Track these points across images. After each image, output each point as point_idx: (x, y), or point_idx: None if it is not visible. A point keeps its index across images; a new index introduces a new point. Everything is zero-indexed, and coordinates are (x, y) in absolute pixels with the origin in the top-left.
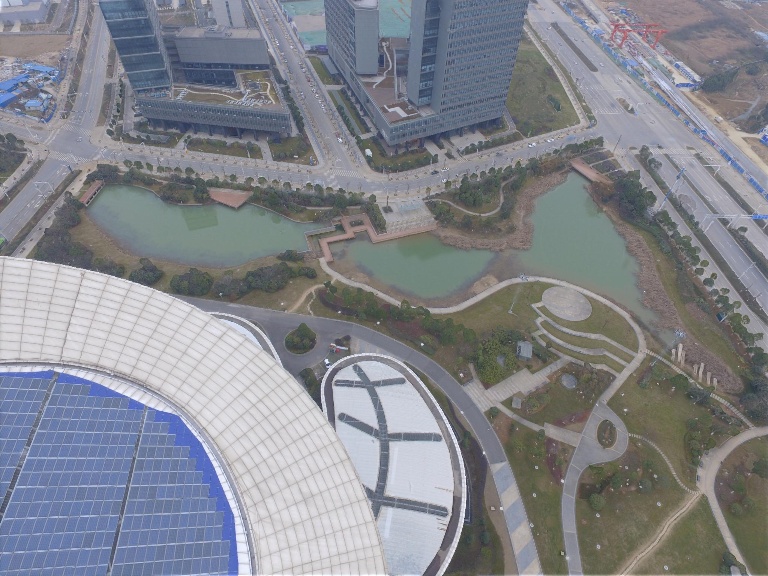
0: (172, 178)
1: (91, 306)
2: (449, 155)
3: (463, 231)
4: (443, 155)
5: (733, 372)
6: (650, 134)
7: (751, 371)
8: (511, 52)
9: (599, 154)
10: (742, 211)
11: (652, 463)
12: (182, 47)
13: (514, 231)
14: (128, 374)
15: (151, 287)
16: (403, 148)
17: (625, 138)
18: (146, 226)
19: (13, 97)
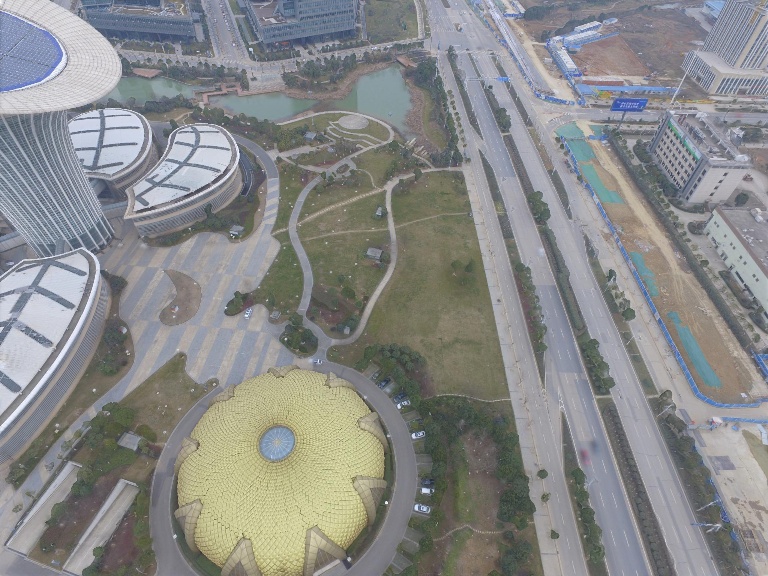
0: None
1: None
2: (310, 53)
3: (302, 90)
4: (306, 53)
5: (441, 150)
6: (465, 43)
7: None
8: None
9: (419, 53)
10: (502, 81)
11: None
12: None
13: (337, 90)
14: (29, 18)
15: (84, 112)
16: None
17: (446, 45)
18: None
19: None
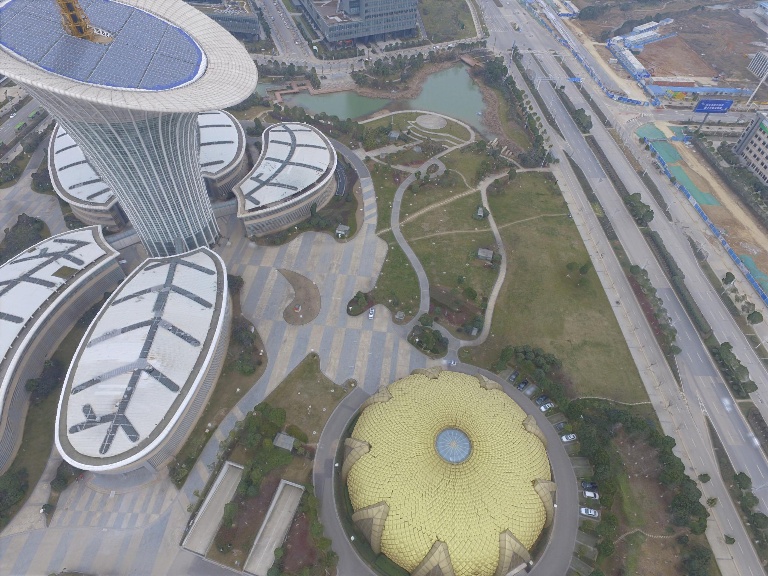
0: None
1: None
2: (373, 51)
3: (373, 89)
4: (369, 52)
5: (524, 150)
6: (526, 42)
7: None
8: None
9: (482, 52)
10: (571, 82)
11: None
12: None
13: (408, 89)
14: (162, 16)
15: None
16: (341, 47)
17: (506, 45)
18: None
19: None
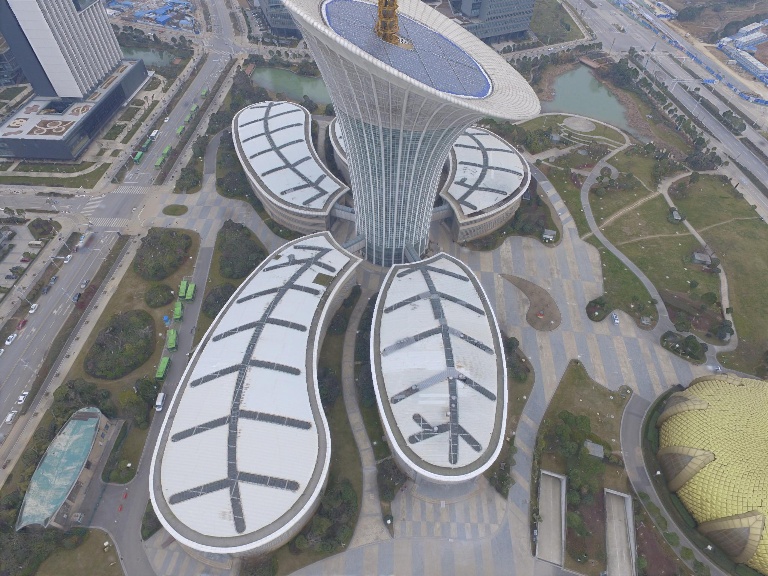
0: (302, 63)
1: None
2: None
3: None
4: None
5: (684, 153)
6: (636, 44)
7: (695, 151)
8: None
9: (599, 54)
10: (699, 83)
11: (631, 173)
12: None
13: (542, 92)
14: (419, 21)
15: (312, 113)
16: None
17: (618, 46)
18: None
19: (169, 18)
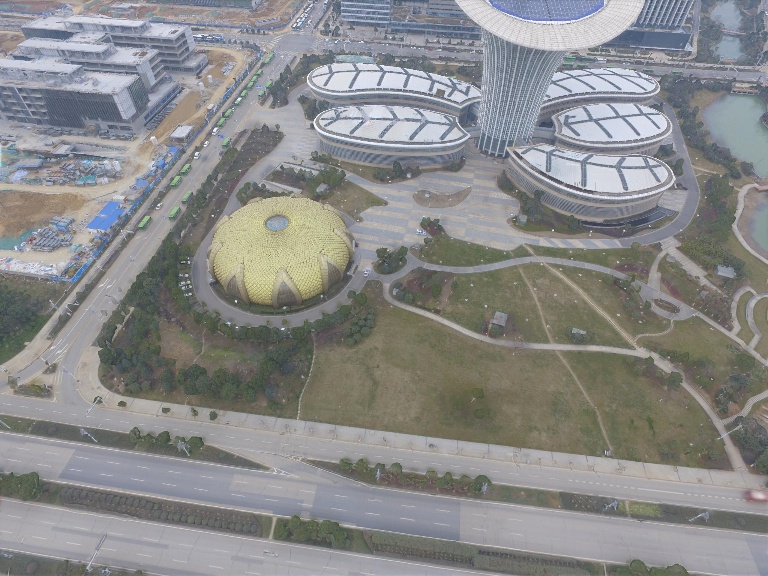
0: None
1: None
2: None
3: None
4: None
5: None
6: None
7: None
8: None
9: None
10: None
11: (649, 302)
12: None
13: None
14: None
15: (680, 118)
16: None
17: None
18: (732, 117)
19: None
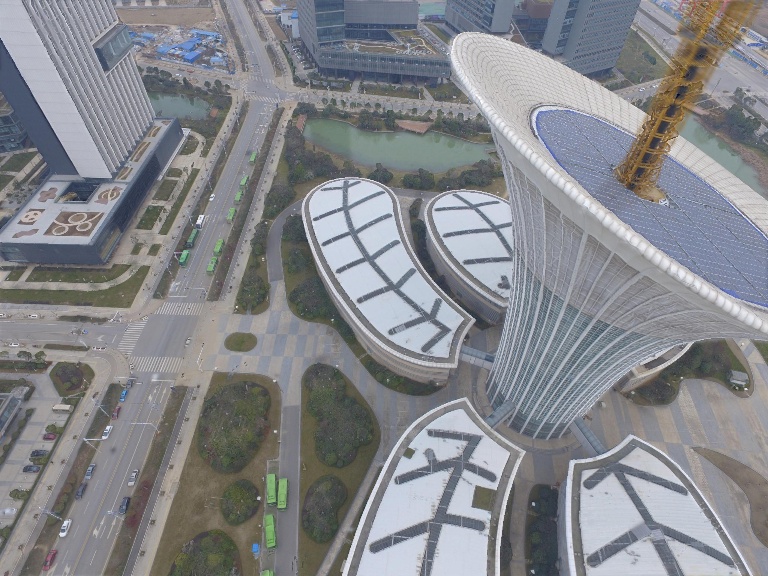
0: (361, 113)
1: (592, 91)
2: None
3: None
4: None
5: None
6: (737, 81)
7: None
8: (634, 8)
9: (700, 95)
10: None
11: None
12: (347, 9)
13: None
14: (620, 126)
15: (387, 184)
16: None
17: None
18: None
19: (198, 54)
